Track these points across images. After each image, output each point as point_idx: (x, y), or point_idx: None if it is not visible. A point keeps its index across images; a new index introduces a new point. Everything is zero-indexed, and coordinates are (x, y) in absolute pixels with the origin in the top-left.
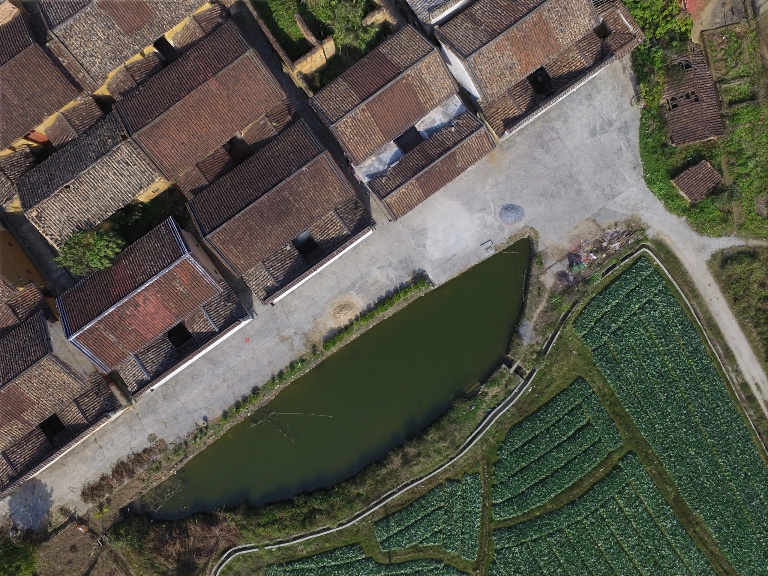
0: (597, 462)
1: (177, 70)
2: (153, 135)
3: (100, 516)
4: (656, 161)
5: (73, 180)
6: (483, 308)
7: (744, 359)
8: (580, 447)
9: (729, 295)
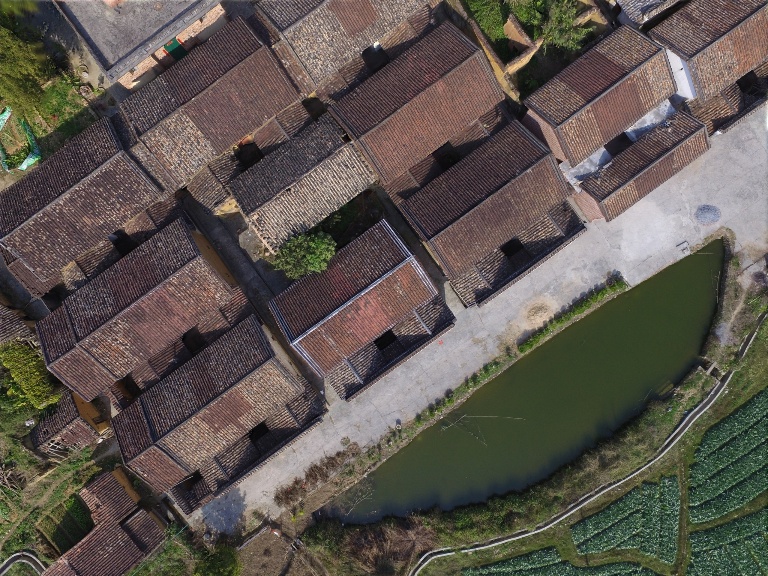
0: None
1: (397, 72)
2: (378, 137)
3: (294, 520)
4: None
5: (295, 183)
6: (676, 310)
7: None
8: None
9: None
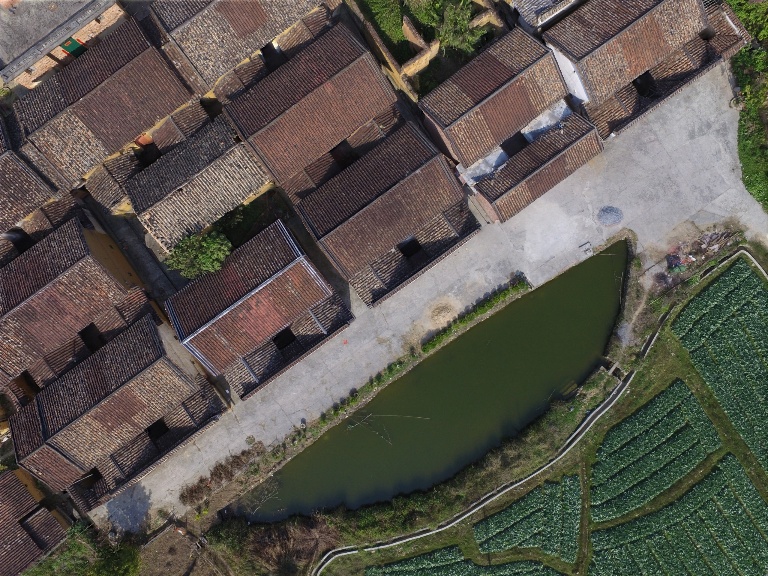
0: (696, 464)
1: (289, 73)
2: (268, 138)
3: (199, 518)
4: (755, 163)
5: (186, 183)
6: (580, 310)
7: None
8: (679, 449)
9: None
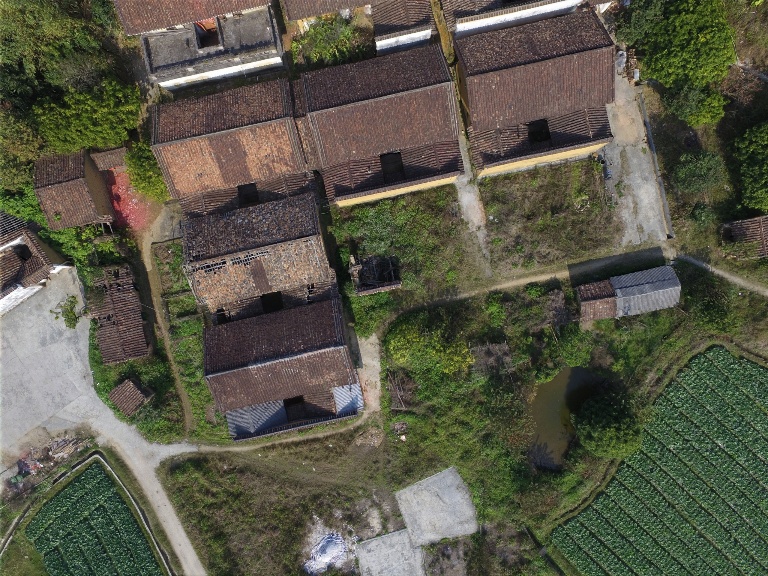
0: None
1: None
2: None
3: None
4: (104, 371)
5: None
6: None
7: (189, 565)
8: None
9: (173, 503)
